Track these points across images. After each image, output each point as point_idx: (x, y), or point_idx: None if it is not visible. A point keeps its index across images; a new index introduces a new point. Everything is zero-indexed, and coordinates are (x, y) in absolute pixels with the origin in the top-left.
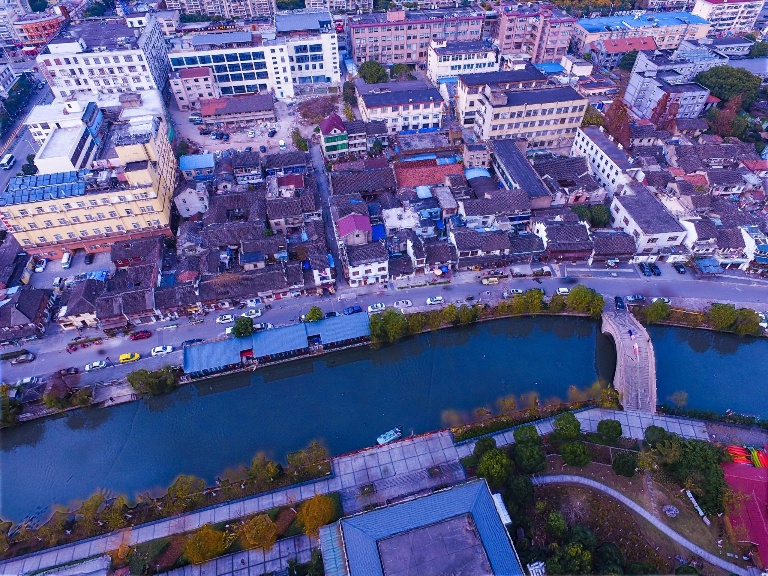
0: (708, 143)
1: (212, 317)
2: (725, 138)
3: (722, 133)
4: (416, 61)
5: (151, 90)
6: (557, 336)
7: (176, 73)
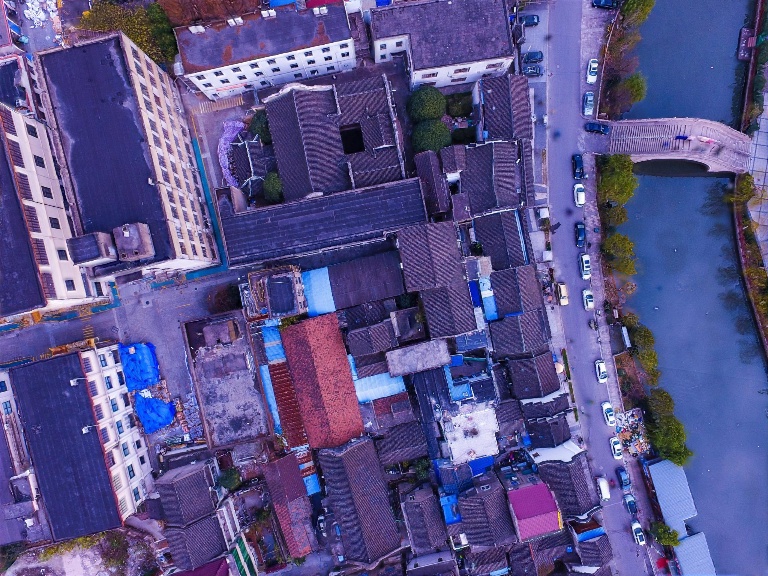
0: None
1: None
2: None
3: None
4: None
5: None
6: None
7: None
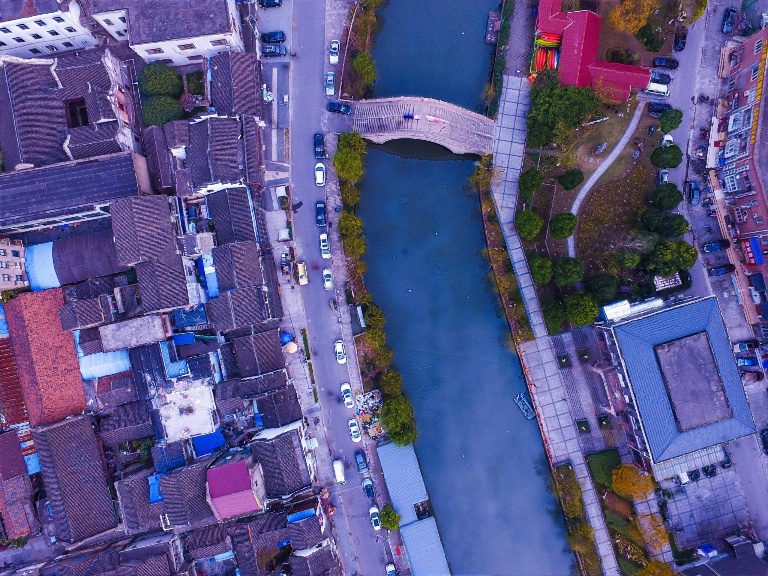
0: None
1: None
2: None
3: None
4: None
5: None
6: (360, 192)
7: None
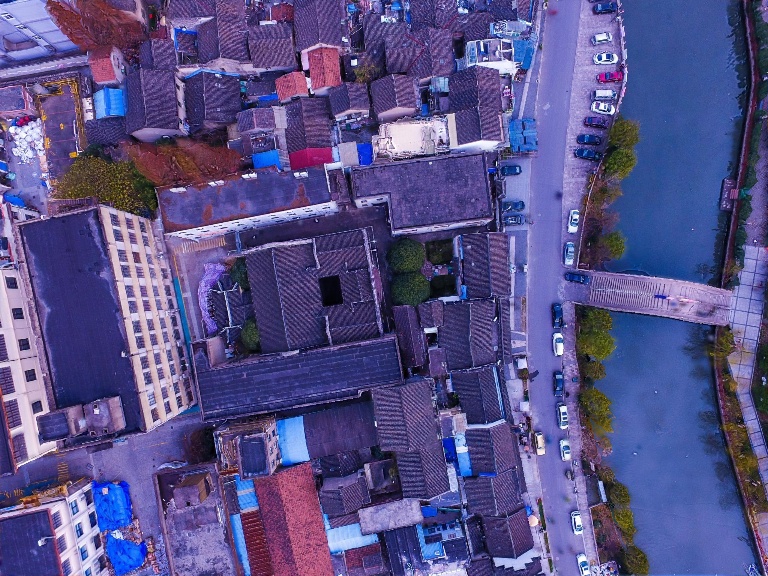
0: None
1: None
2: None
3: None
4: None
5: None
6: None
7: None
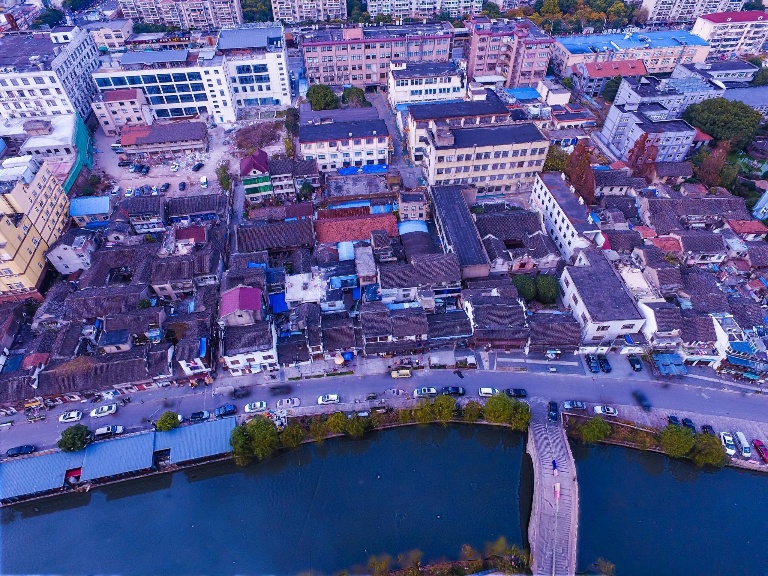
0: (690, 195)
1: (57, 413)
2: (711, 188)
3: (708, 182)
4: (377, 82)
5: (68, 115)
6: (479, 444)
7: (99, 95)
